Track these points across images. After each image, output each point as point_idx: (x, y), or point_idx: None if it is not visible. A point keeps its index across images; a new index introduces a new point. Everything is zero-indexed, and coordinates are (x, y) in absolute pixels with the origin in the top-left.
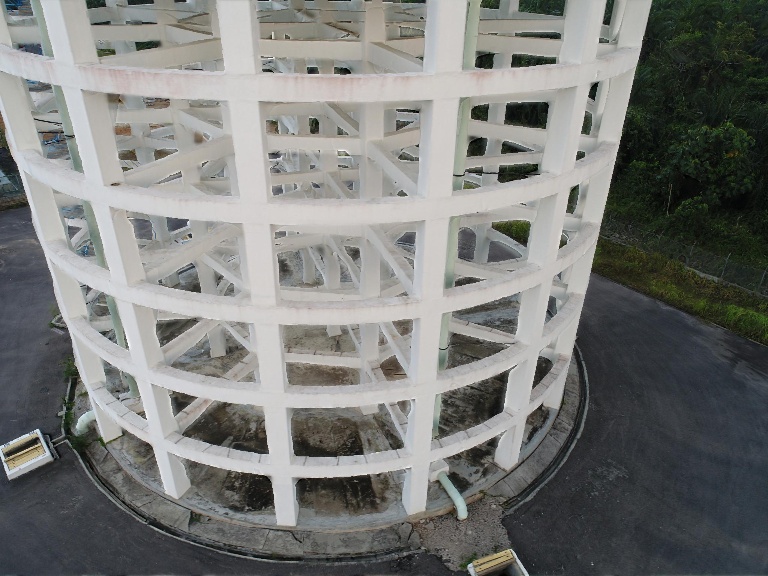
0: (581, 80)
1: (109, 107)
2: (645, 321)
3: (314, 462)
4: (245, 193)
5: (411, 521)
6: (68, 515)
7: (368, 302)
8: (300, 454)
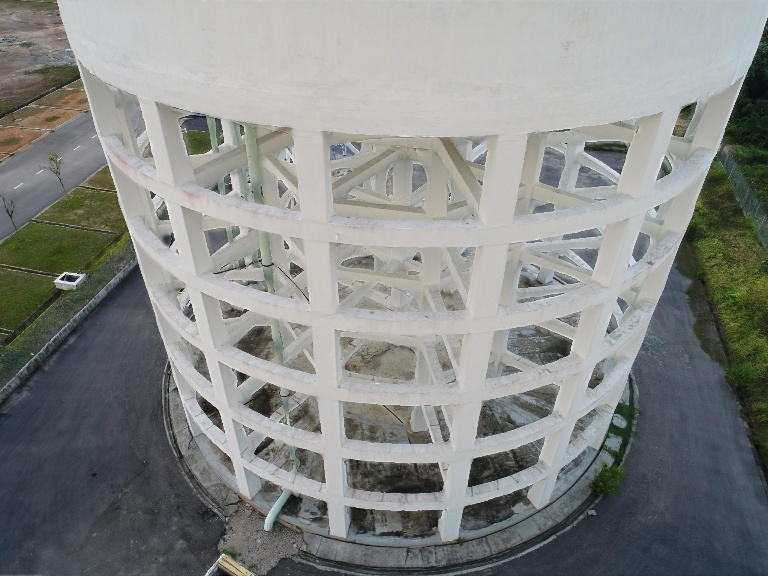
0: (308, 235)
1: (127, 118)
2: (719, 575)
3: (191, 404)
4: (121, 206)
5: (242, 498)
6: (153, 340)
7: (182, 319)
8: (258, 402)
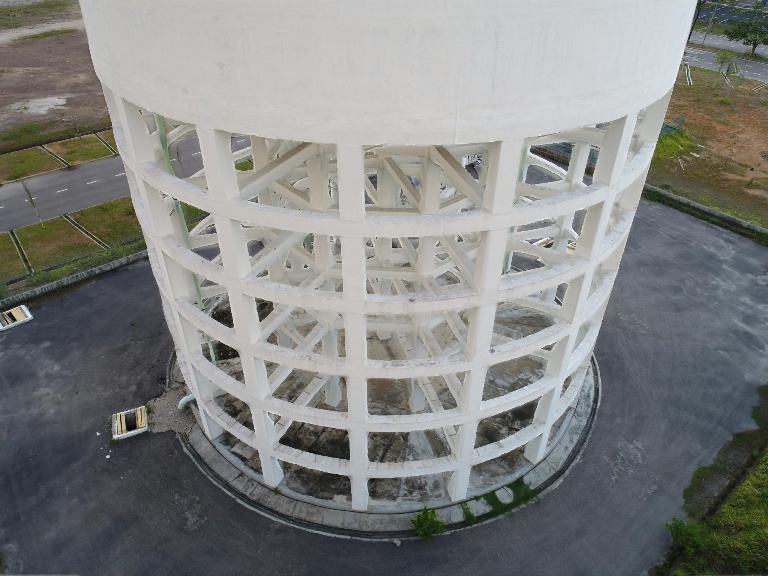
0: (135, 171)
1: None
2: None
3: None
4: None
5: None
6: None
7: None
8: None
